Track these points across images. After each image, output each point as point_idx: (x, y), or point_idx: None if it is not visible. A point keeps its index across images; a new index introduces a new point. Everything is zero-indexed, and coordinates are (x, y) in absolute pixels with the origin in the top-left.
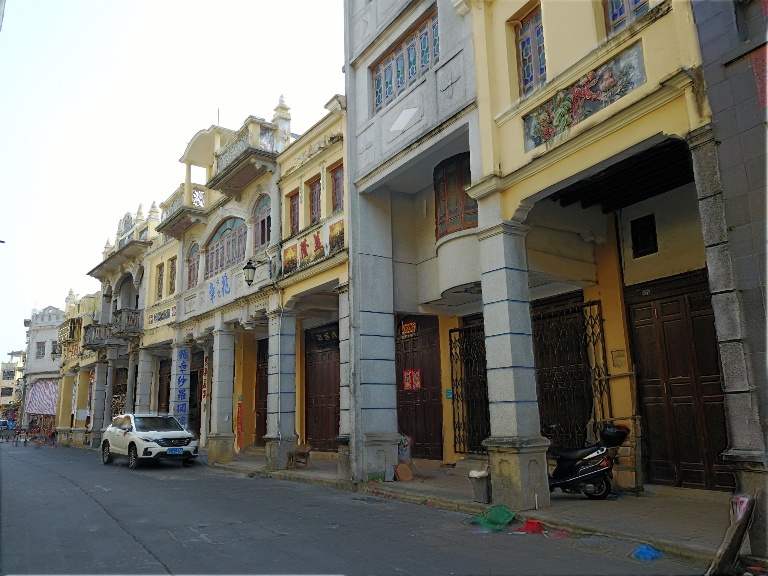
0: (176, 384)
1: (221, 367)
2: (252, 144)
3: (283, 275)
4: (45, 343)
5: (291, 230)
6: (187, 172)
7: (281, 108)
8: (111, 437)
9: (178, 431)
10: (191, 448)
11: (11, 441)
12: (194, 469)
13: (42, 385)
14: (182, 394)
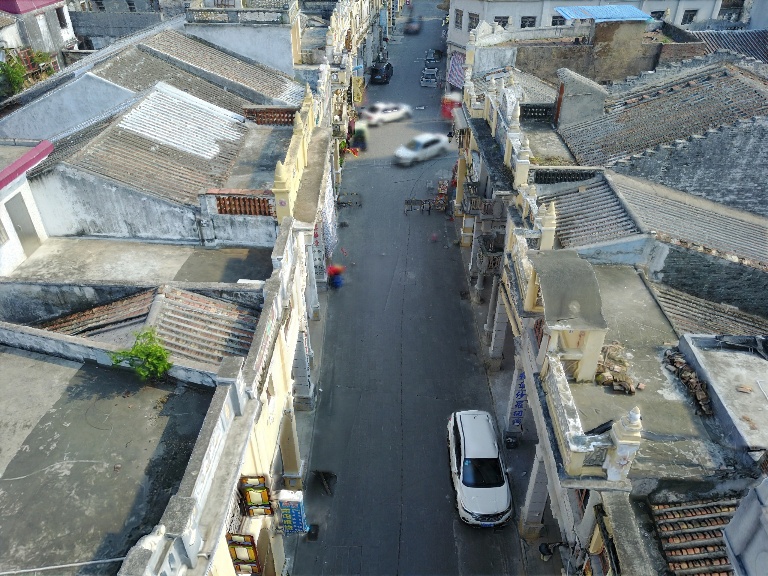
0: (514, 397)
1: (537, 483)
2: (569, 470)
3: (582, 573)
4: (462, 13)
5: (602, 549)
6: (532, 271)
7: (627, 430)
8: (450, 445)
9: (497, 490)
10: (503, 520)
11: (418, 210)
12: (503, 536)
13: (461, 57)
14: (519, 404)
